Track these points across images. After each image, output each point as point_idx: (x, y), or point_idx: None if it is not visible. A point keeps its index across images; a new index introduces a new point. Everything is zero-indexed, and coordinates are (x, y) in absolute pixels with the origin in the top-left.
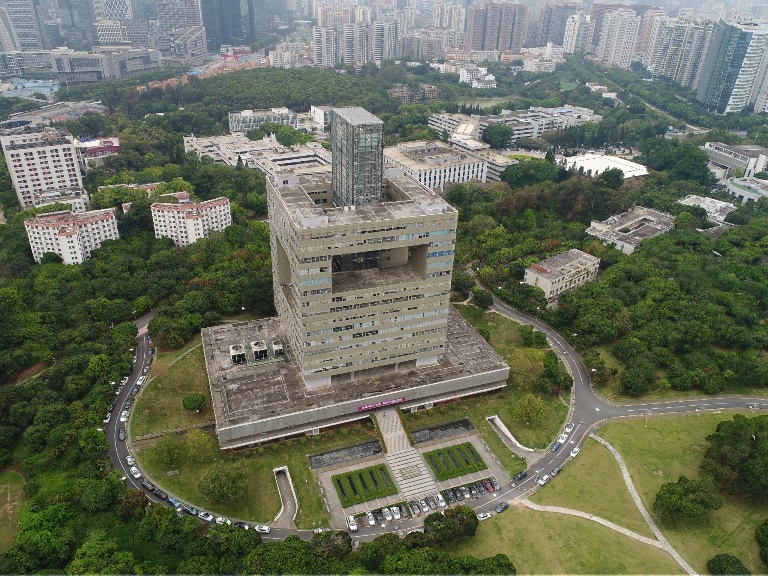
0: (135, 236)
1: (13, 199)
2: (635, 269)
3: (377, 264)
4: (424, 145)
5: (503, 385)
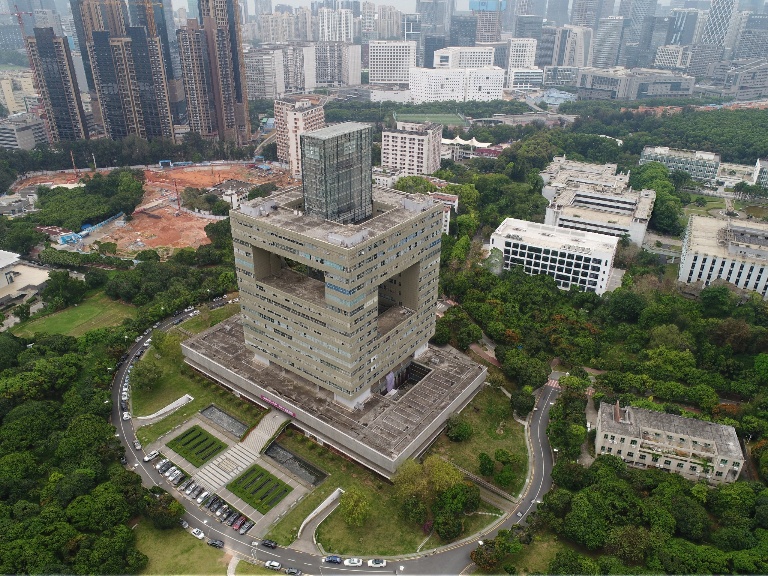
0: None
1: None
2: None
3: None
4: (763, 229)
5: (389, 477)
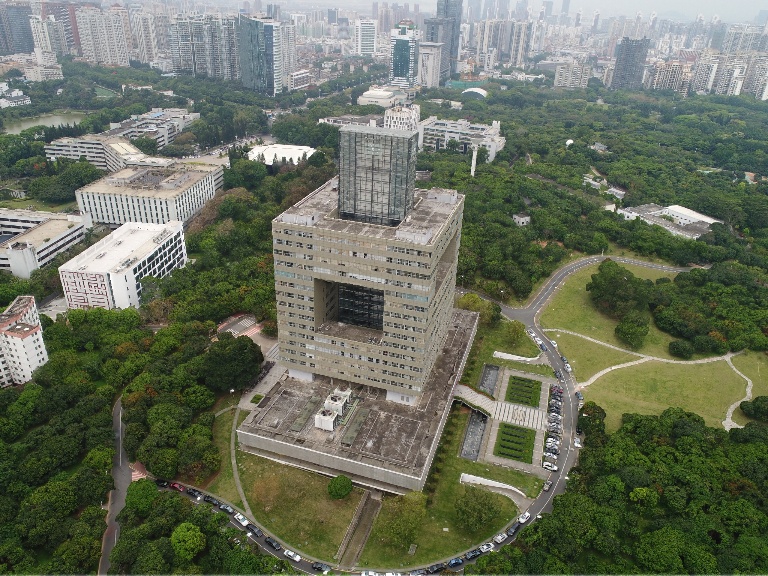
0: None
1: None
2: None
3: None
4: (136, 172)
5: (476, 329)
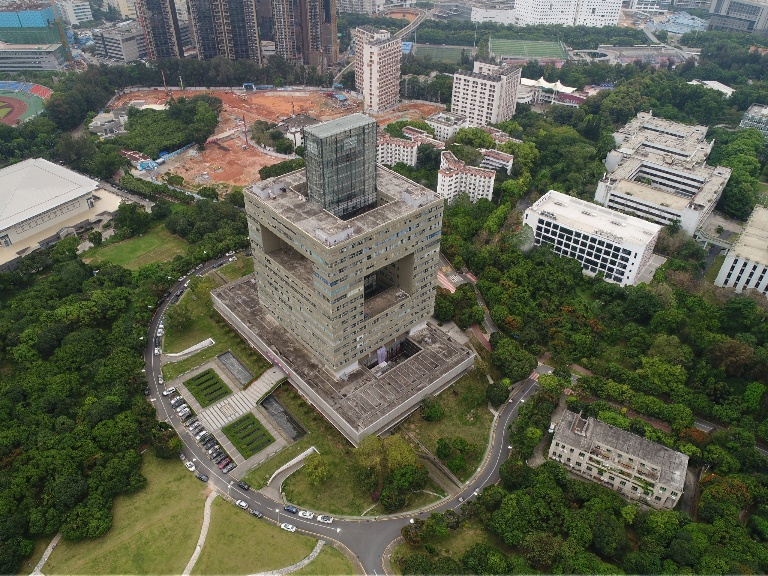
0: (427, 170)
1: (450, 111)
2: (688, 543)
3: None
4: None
5: (355, 445)
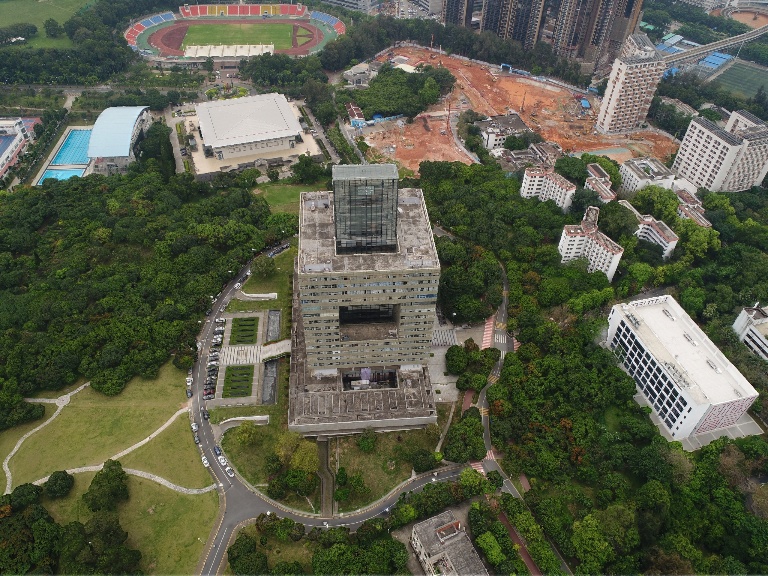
0: (574, 218)
1: None
2: None
3: None
4: None
5: None
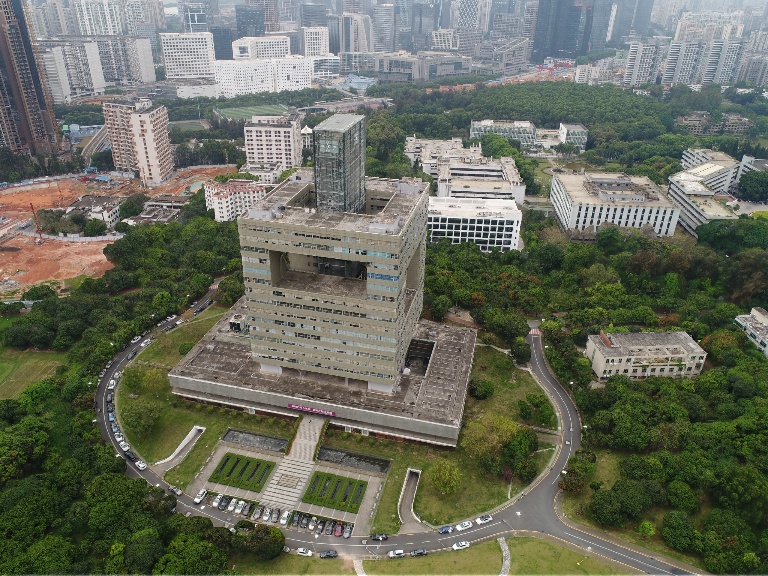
0: None
1: None
2: (744, 380)
3: (344, 273)
4: (614, 178)
5: (451, 444)
